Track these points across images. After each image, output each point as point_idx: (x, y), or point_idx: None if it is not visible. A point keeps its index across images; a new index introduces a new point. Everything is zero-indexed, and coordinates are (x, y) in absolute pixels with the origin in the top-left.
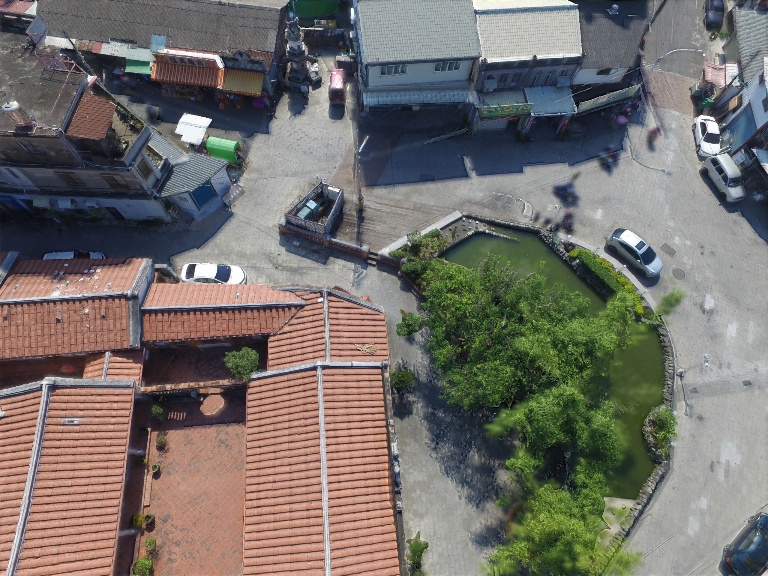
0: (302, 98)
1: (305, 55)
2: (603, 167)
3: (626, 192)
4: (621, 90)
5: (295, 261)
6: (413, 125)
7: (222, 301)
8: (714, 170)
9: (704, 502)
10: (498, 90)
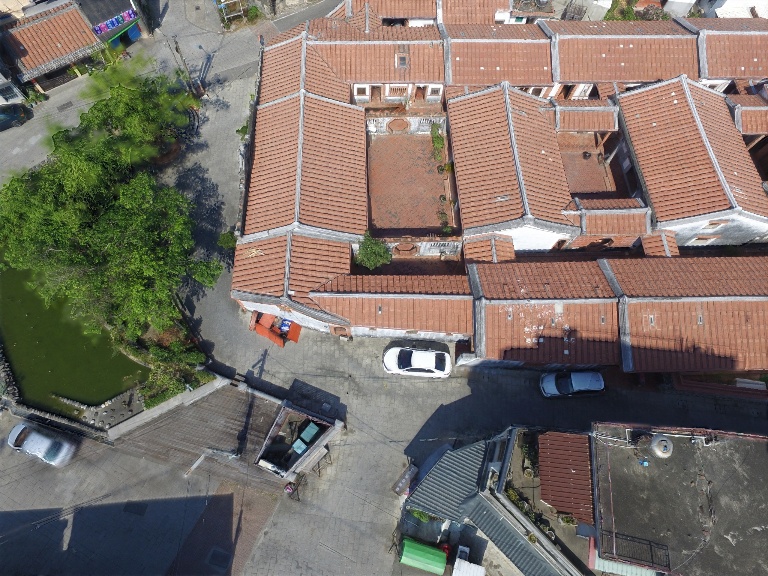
0: None
1: None
2: None
3: None
4: None
5: (329, 384)
6: None
7: (395, 304)
8: None
9: (15, 151)
10: None
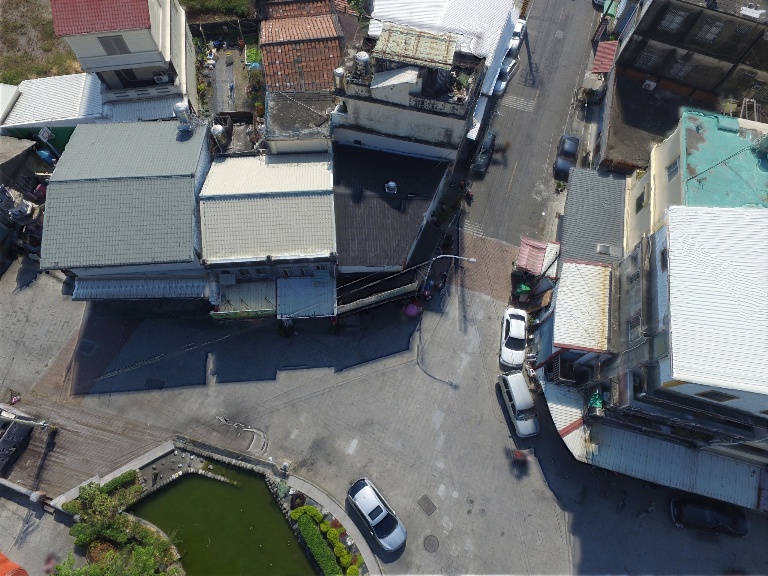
0: (37, 263)
1: (32, 218)
2: (376, 375)
3: (396, 414)
4: (391, 290)
5: None
6: (158, 307)
7: None
8: (505, 393)
9: None
10: (245, 280)
